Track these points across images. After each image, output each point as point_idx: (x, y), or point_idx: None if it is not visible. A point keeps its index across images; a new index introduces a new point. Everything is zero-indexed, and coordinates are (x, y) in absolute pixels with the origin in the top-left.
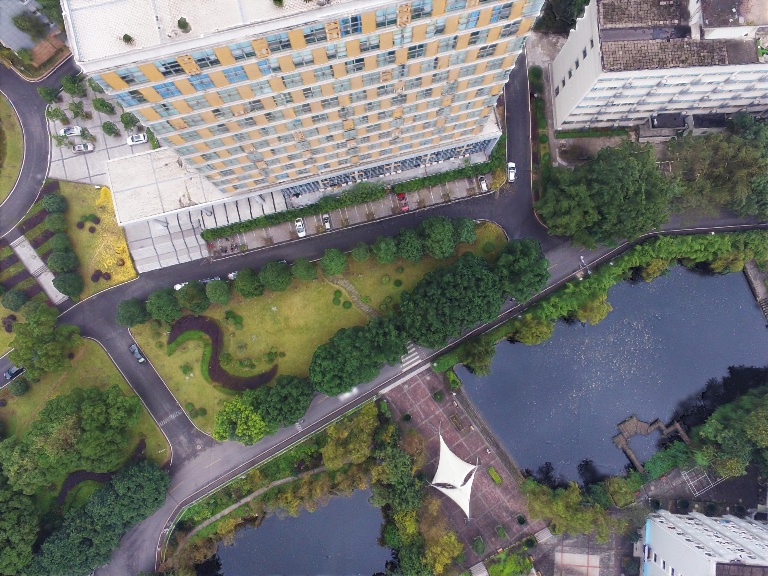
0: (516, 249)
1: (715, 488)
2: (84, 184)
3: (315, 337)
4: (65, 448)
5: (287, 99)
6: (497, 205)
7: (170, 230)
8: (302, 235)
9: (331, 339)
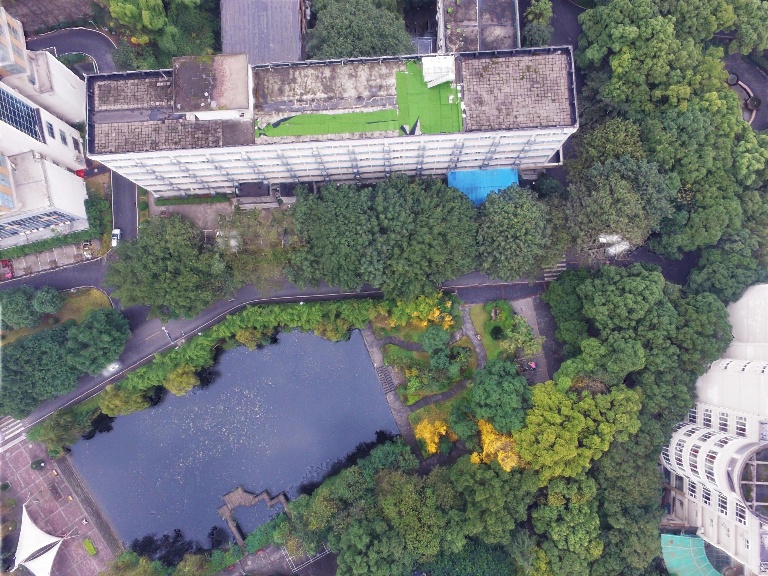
0: None
1: (314, 564)
2: None
3: None
4: None
5: None
6: (104, 271)
7: None
8: None
9: None
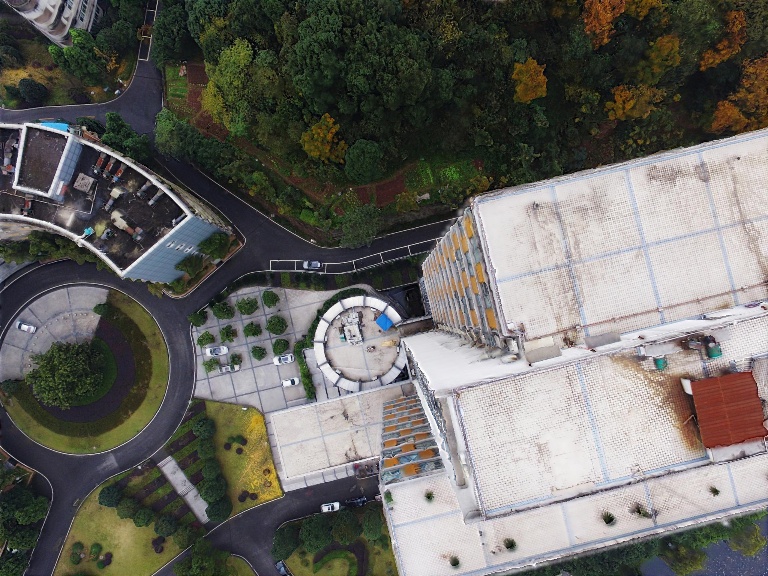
0: None
1: None
2: (230, 404)
3: None
4: None
5: None
6: None
7: None
8: None
9: None
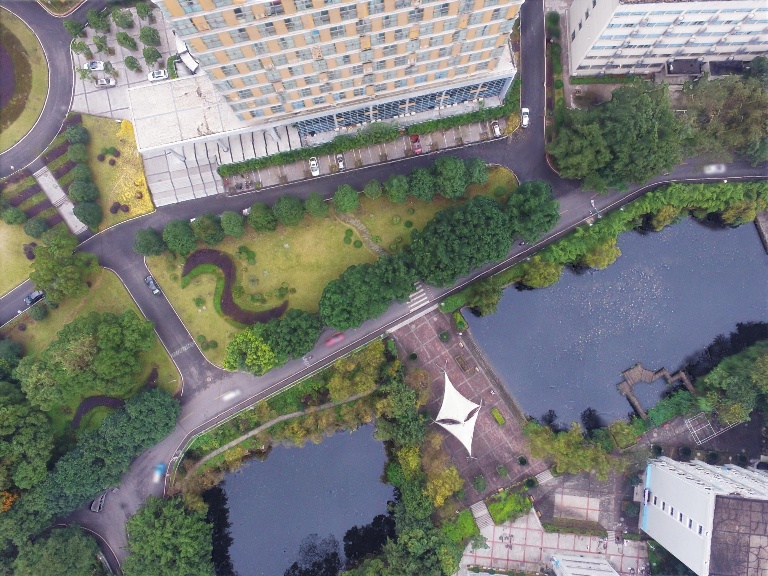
0: (527, 189)
1: (718, 437)
2: (105, 118)
3: (325, 275)
4: (81, 366)
5: (307, 3)
6: (509, 150)
7: (187, 165)
8: (316, 174)
9: (341, 275)
